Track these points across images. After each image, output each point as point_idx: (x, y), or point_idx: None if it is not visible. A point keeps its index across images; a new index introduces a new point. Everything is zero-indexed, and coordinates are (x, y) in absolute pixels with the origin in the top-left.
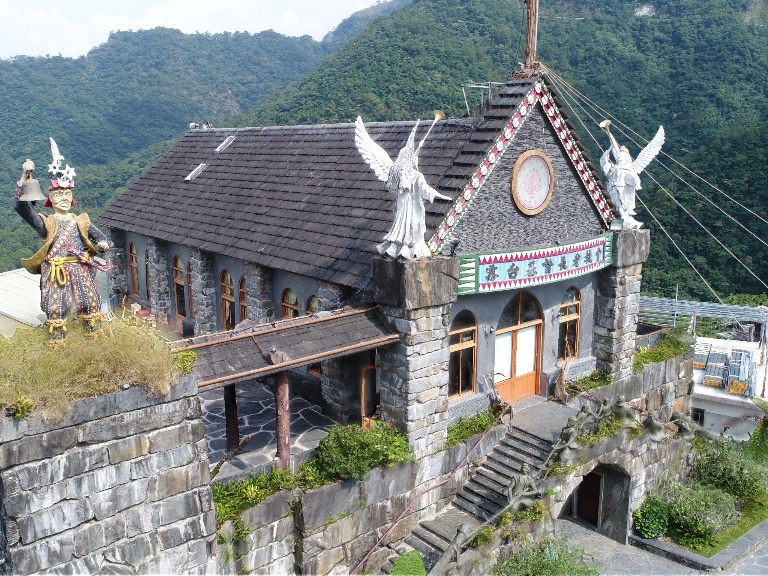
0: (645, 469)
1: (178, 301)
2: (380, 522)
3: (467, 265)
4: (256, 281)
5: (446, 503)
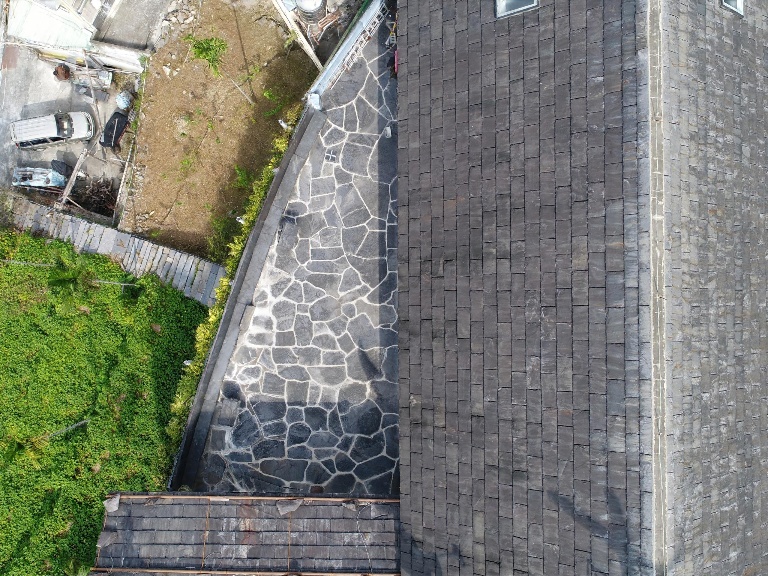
0: None
1: None
2: None
3: None
4: None
5: None
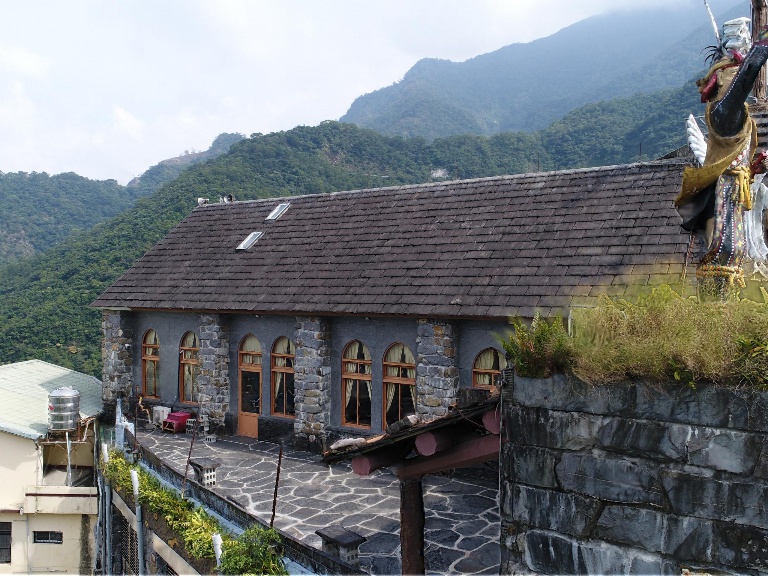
0: None
1: (241, 395)
2: None
3: None
4: (442, 342)
5: None
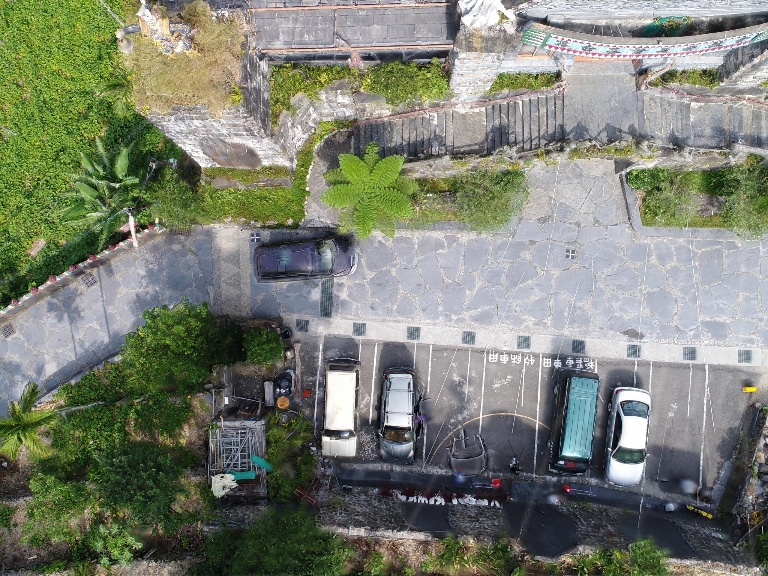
0: (659, 161)
1: None
2: (418, 105)
3: (537, 33)
4: None
5: (481, 106)
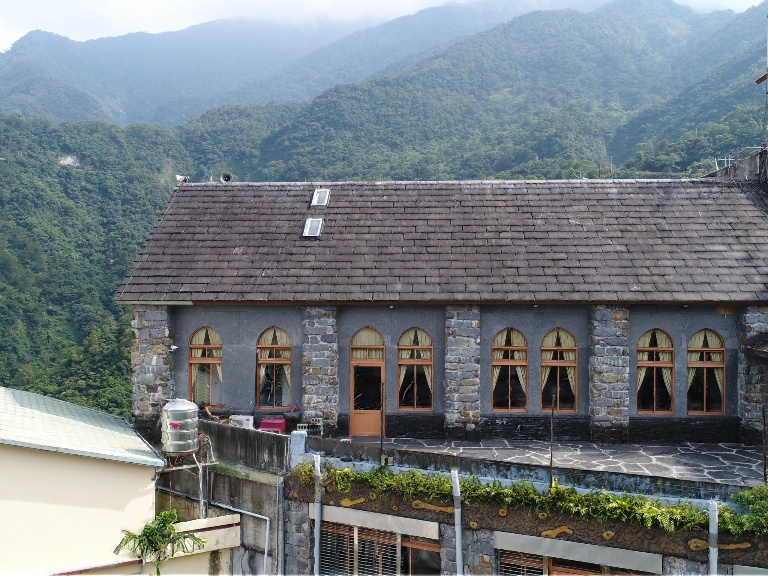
0: None
1: None
2: None
3: None
4: (621, 325)
5: None
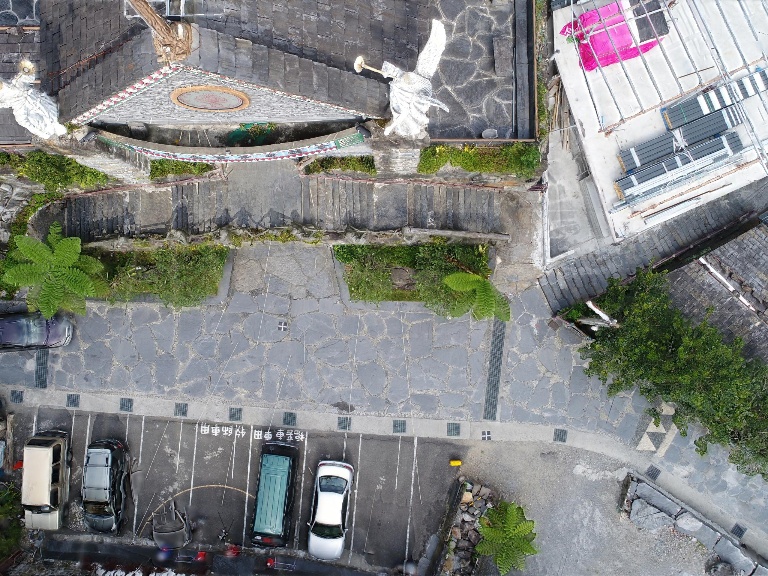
0: None
1: None
2: None
3: None
4: None
5: (166, 186)
